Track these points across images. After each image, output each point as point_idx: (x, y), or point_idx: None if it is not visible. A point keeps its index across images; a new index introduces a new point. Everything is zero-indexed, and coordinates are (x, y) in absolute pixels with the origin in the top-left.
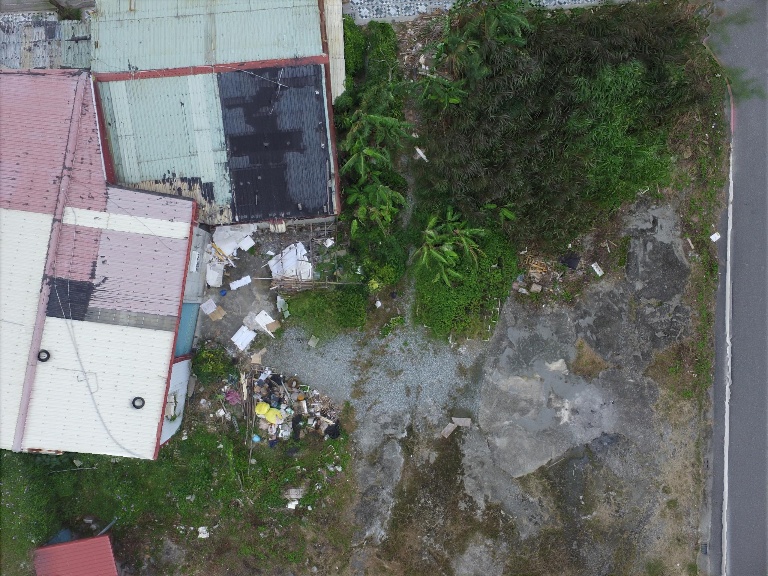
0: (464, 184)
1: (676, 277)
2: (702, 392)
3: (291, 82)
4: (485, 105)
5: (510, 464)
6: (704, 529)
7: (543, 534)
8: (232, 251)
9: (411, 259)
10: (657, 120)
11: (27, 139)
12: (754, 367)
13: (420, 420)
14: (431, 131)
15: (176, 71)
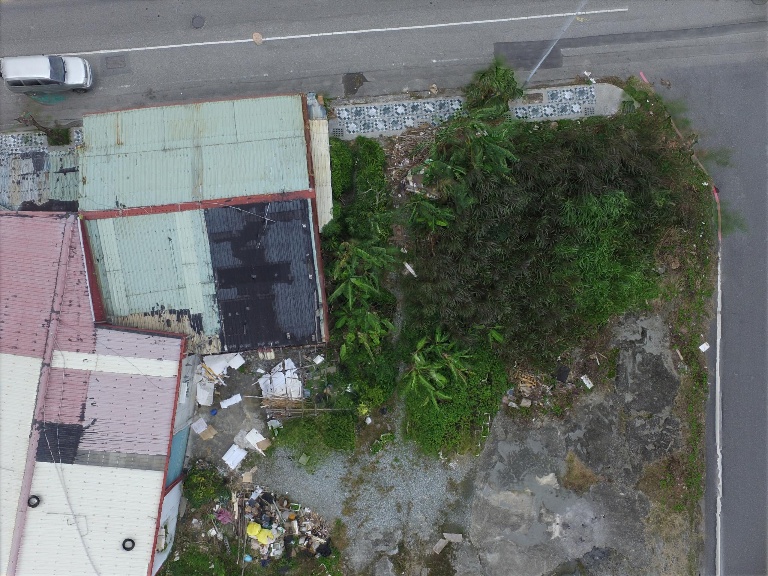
0: (452, 311)
1: (666, 389)
2: (693, 504)
3: (278, 216)
4: (472, 230)
5: None
6: None
7: None
8: (222, 370)
9: (401, 374)
10: (644, 239)
11: (15, 282)
12: (745, 479)
13: (411, 536)
14: (419, 251)
15: (163, 208)
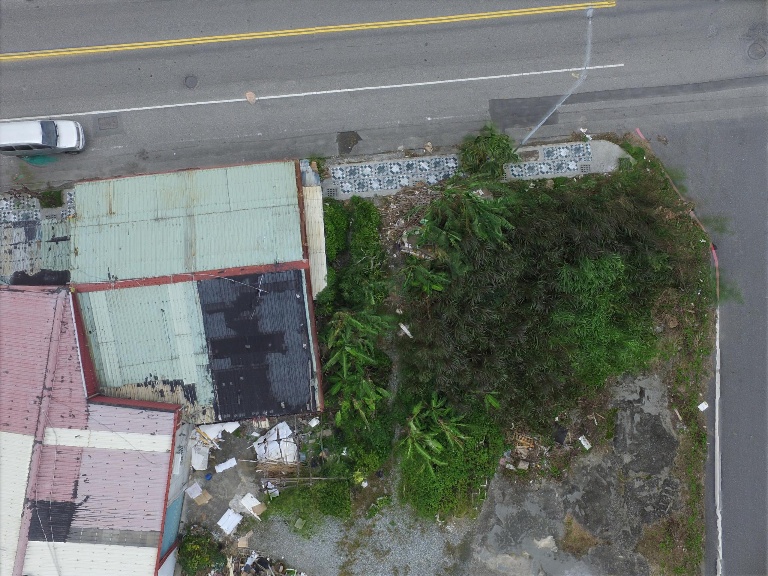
0: (447, 379)
1: (664, 450)
2: (693, 567)
3: (271, 287)
4: (467, 296)
5: None
6: None
7: None
8: (217, 434)
9: (397, 436)
10: (641, 302)
11: (7, 357)
12: (745, 540)
13: None
14: (414, 314)
15: (156, 280)
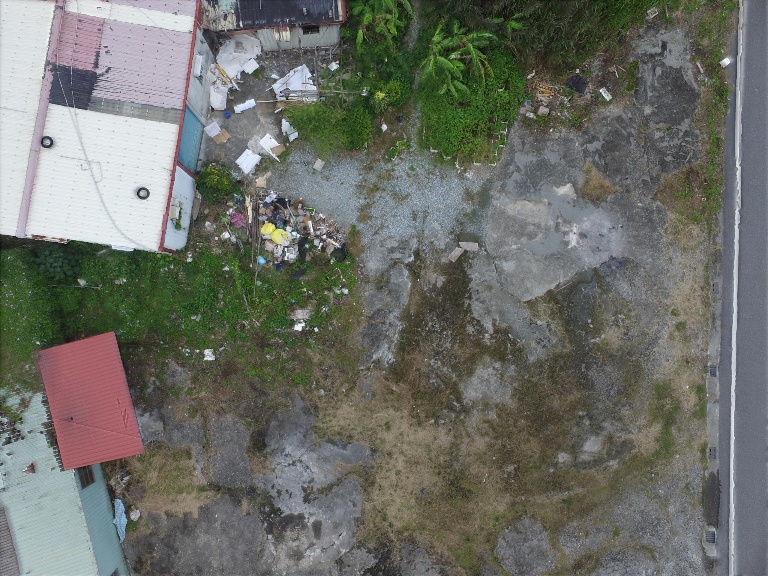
0: None
1: (685, 101)
2: (711, 216)
3: None
4: None
5: (518, 288)
6: (713, 352)
7: (551, 357)
8: (236, 73)
9: (417, 83)
10: None
11: None
12: (764, 191)
13: (427, 244)
14: None
15: None
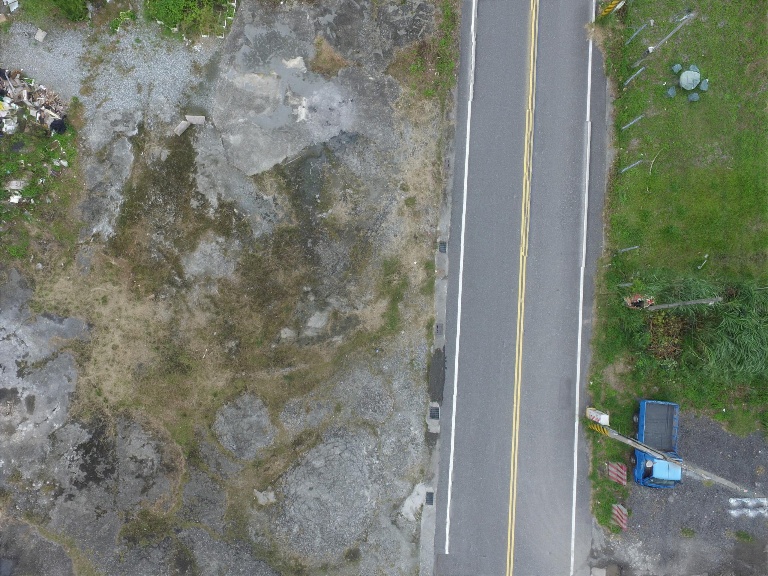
0: None
1: None
2: (445, 91)
3: None
4: None
5: (244, 162)
6: (443, 228)
7: (277, 232)
8: None
9: None
10: None
11: None
12: (499, 66)
13: (152, 118)
14: None
15: None
